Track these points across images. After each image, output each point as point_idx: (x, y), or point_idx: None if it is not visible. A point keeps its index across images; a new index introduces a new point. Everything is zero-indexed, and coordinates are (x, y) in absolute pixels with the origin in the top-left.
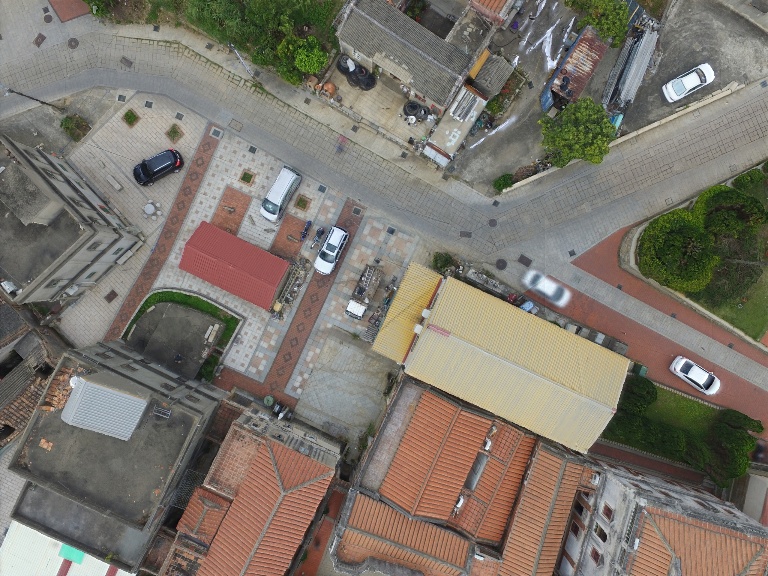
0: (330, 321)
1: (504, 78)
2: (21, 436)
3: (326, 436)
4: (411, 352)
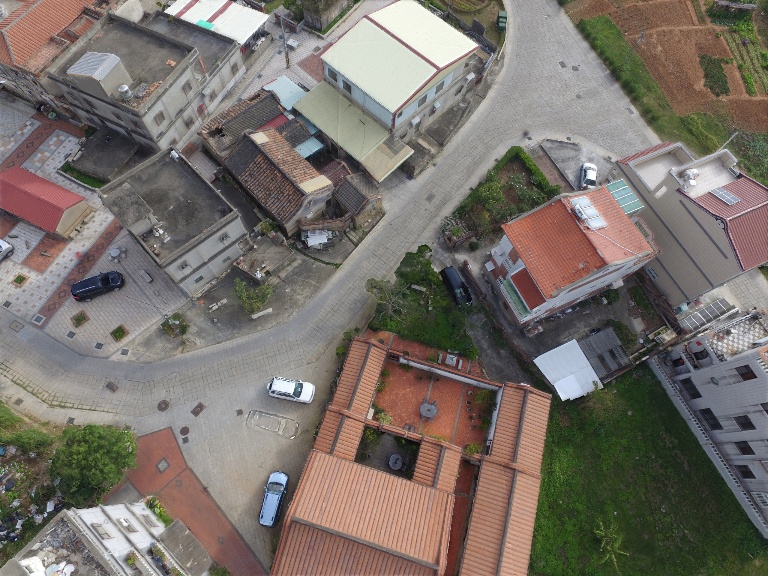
0: None
1: None
2: None
3: (18, 95)
4: None
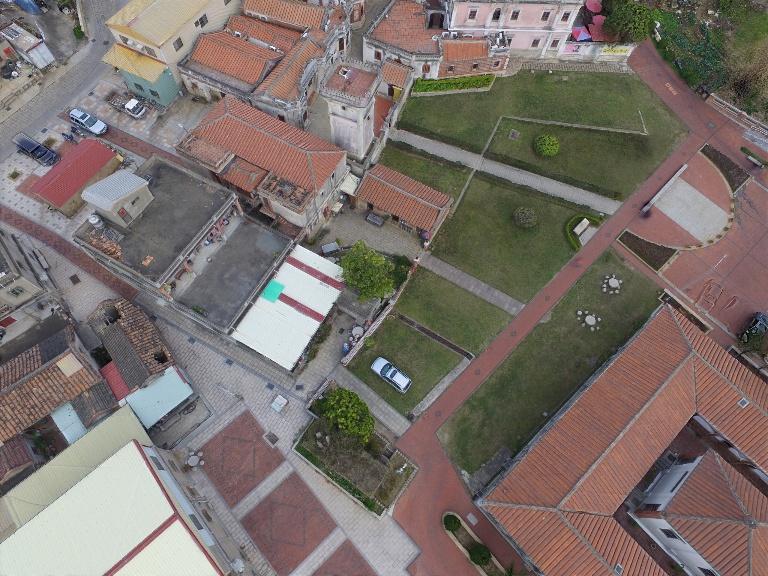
0: (144, 132)
1: (4, 18)
2: (180, 365)
3: None
4: (154, 51)
